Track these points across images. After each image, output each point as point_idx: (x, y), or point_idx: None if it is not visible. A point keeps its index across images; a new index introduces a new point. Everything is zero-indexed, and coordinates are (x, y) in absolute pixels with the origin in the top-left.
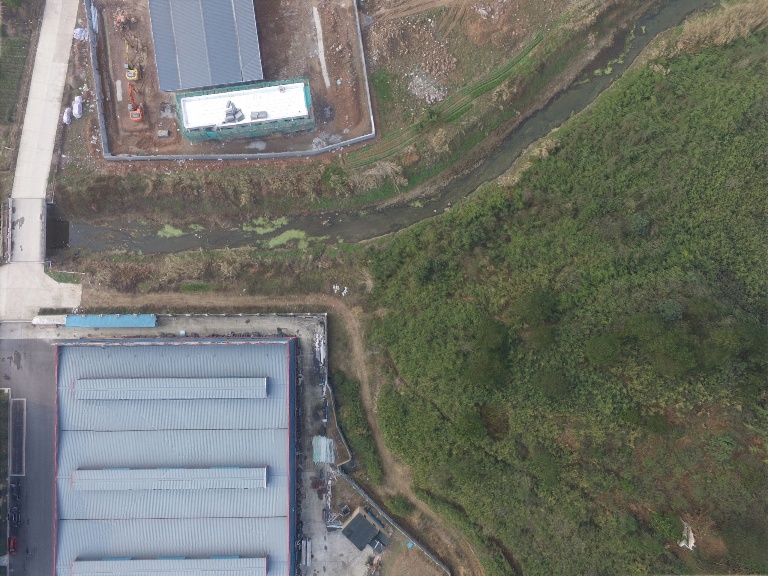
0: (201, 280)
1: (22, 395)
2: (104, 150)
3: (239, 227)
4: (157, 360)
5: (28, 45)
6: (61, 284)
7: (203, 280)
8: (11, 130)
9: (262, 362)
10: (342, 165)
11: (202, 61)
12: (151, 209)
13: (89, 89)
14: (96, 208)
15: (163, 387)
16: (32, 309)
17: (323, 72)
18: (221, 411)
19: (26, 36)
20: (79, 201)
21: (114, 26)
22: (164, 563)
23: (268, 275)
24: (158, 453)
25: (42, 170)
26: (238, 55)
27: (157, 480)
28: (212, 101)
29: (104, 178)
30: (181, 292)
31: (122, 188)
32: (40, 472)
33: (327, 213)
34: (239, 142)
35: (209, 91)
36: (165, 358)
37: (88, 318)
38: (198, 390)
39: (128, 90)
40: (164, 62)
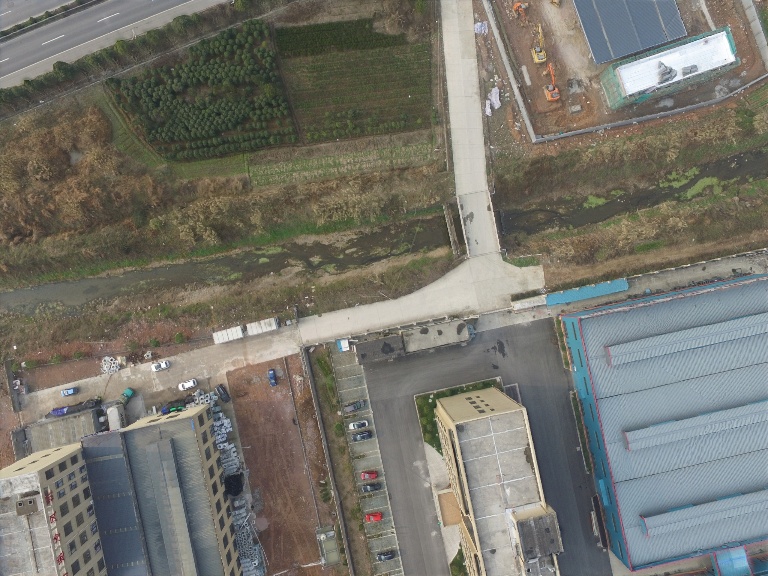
0: (651, 239)
1: (513, 381)
2: (534, 133)
3: (656, 185)
4: (668, 315)
5: (430, 48)
6: (523, 268)
7: (652, 238)
8: (434, 132)
9: (764, 297)
10: (748, 106)
11: (628, 28)
12: (575, 183)
13: (501, 79)
14: (529, 191)
15: (691, 337)
16: (503, 297)
17: (709, 22)
18: (737, 351)
19: (427, 40)
20: (515, 187)
21: (507, 15)
22: (727, 502)
23: (708, 222)
24: (689, 402)
25: (479, 164)
26: (658, 17)
27: (705, 425)
28: (643, 65)
29: (538, 160)
30: (635, 254)
31: (555, 167)
32: (546, 450)
33: (733, 156)
34: (649, 103)
35: (640, 55)
36: (675, 312)
37: (566, 294)
38: (723, 333)
39: (534, 73)
40: (593, 36)
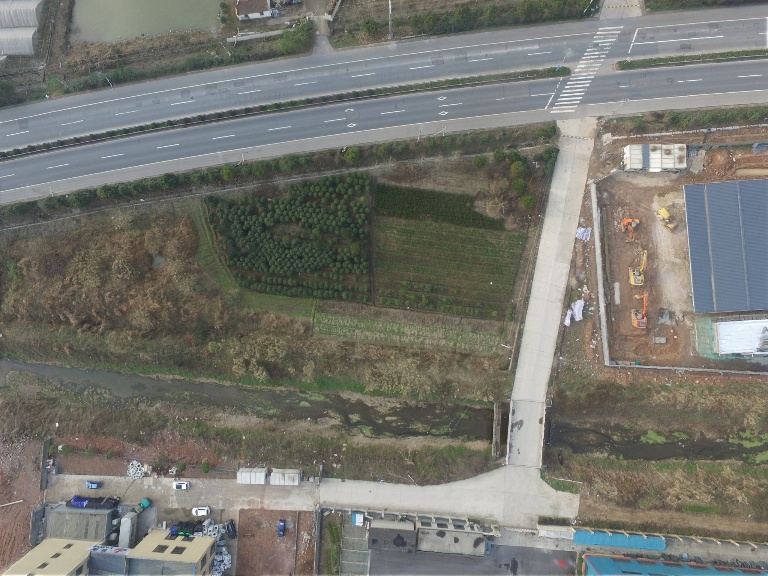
0: (703, 501)
1: None
2: (609, 358)
3: (725, 438)
4: None
5: (525, 240)
6: (559, 492)
7: (705, 501)
8: (506, 326)
9: None
10: None
11: (740, 284)
12: (638, 414)
13: (589, 291)
14: (587, 412)
15: None
16: (530, 516)
17: None
18: None
19: (524, 231)
20: (574, 405)
21: (615, 226)
22: None
23: None
24: None
25: (543, 373)
26: None
27: None
28: (746, 325)
29: (606, 386)
30: (682, 512)
31: (622, 397)
32: None
33: None
34: None
35: (745, 316)
36: None
37: (597, 536)
38: None
39: (626, 293)
40: (700, 283)
